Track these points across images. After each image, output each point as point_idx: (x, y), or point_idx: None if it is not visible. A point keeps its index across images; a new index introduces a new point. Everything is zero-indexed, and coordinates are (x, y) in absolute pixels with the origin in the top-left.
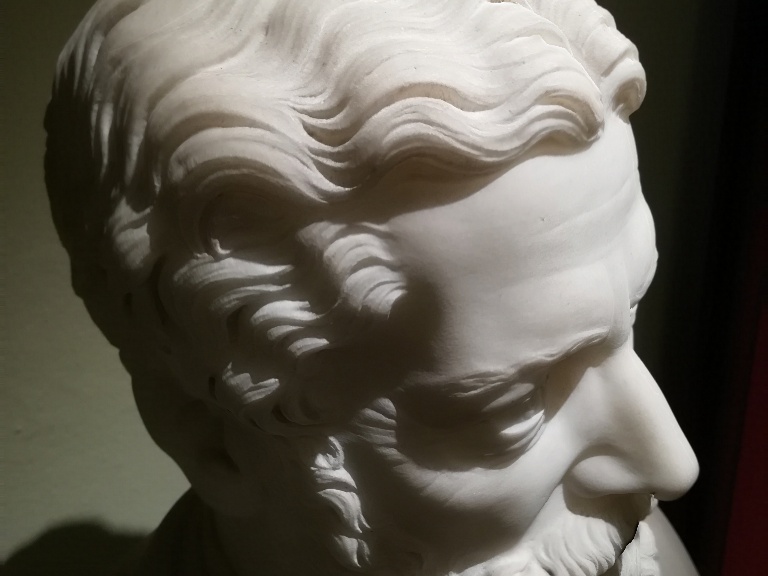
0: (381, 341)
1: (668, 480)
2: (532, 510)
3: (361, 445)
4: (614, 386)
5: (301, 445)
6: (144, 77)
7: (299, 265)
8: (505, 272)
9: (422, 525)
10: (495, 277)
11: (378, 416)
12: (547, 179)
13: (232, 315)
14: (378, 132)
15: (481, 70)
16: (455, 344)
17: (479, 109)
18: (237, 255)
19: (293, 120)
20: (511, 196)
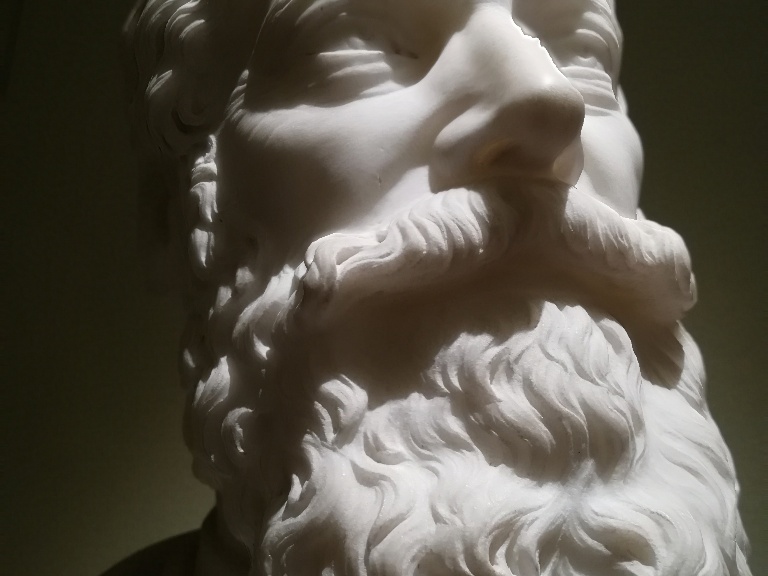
0: (246, 17)
1: (518, 91)
2: (365, 161)
3: None
4: (473, 34)
5: None
6: None
7: None
8: None
9: (259, 198)
10: None
11: None
12: None
13: (159, 34)
14: None
15: None
16: None
17: None
18: None
19: None
20: None
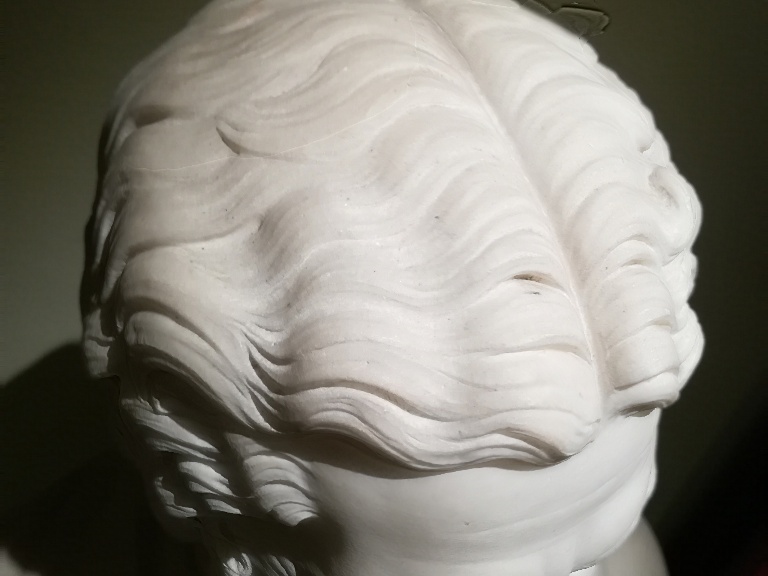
0: (293, 528)
1: None
2: None
3: (265, 575)
4: None
5: (220, 544)
6: (134, 221)
7: (224, 454)
8: (413, 549)
9: None
10: (402, 548)
11: (282, 569)
12: (488, 489)
13: (166, 451)
14: (308, 408)
15: (448, 377)
16: (350, 574)
17: (428, 417)
18: (174, 417)
19: (241, 347)
20: (439, 496)
